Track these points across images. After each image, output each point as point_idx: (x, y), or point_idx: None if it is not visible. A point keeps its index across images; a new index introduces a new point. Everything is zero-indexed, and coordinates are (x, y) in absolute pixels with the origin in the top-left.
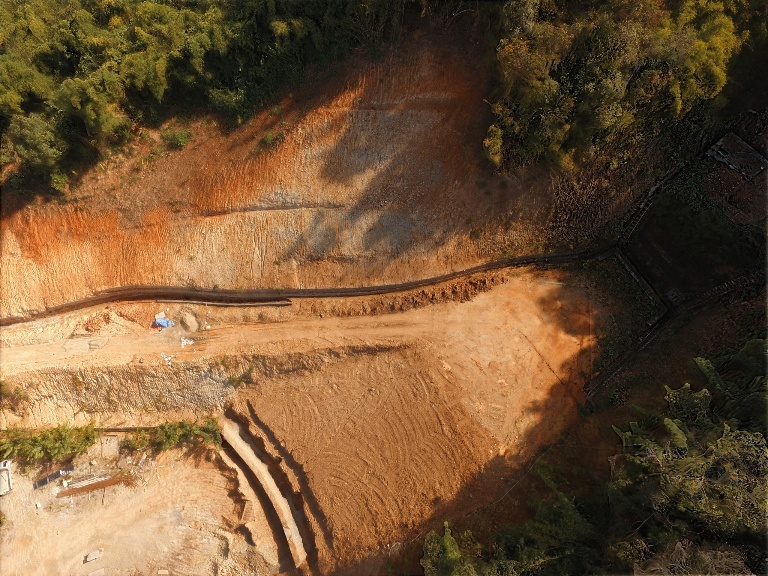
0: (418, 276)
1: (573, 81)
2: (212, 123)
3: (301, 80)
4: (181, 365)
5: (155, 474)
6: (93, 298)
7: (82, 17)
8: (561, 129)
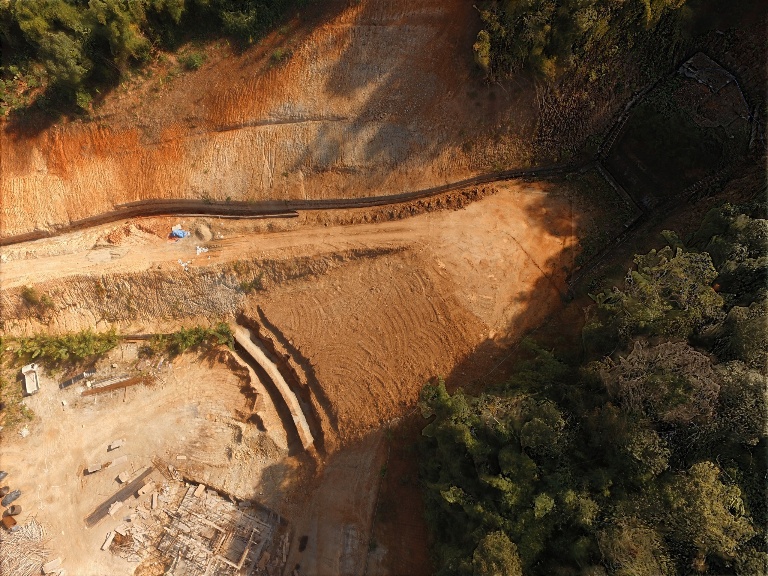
0: (415, 187)
1: None
2: (225, 45)
3: (307, 1)
4: (197, 270)
5: (172, 375)
6: (114, 213)
7: None
8: (542, 31)
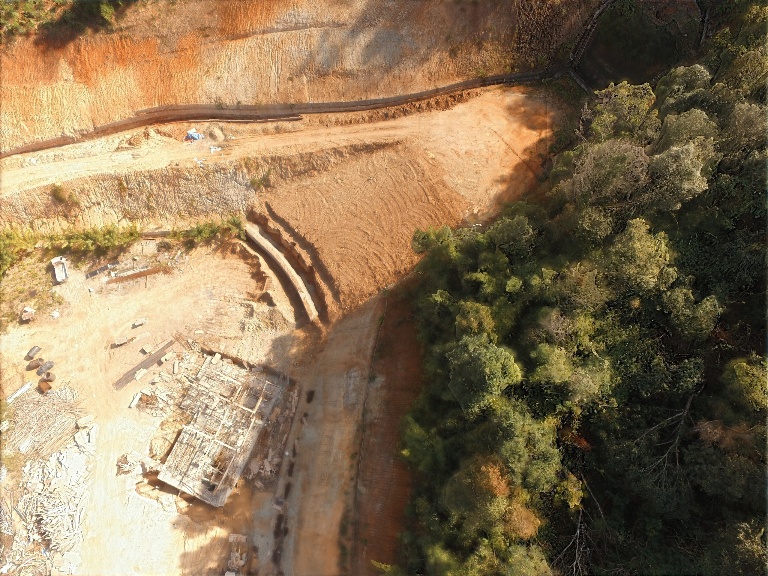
0: (407, 90)
1: None
2: None
3: None
4: (211, 167)
5: (189, 265)
6: (134, 119)
7: None
8: None
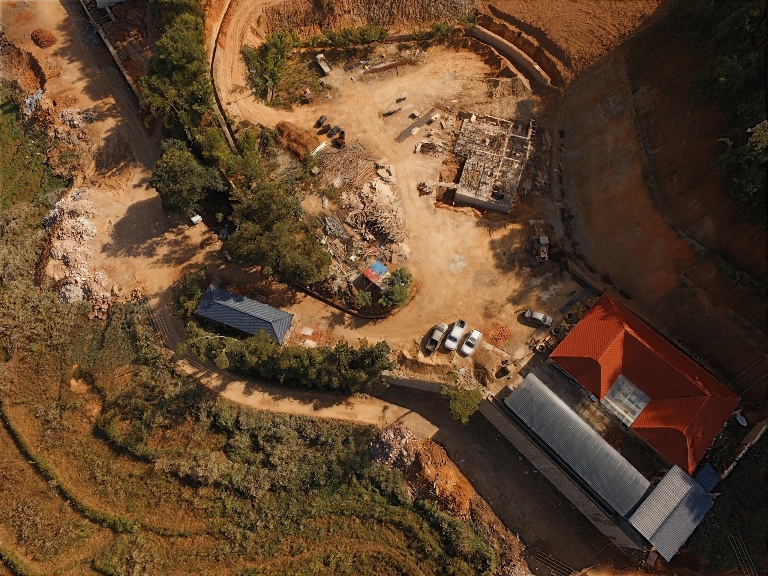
0: None
1: None
2: None
3: None
4: None
5: (429, 58)
6: None
7: None
8: None
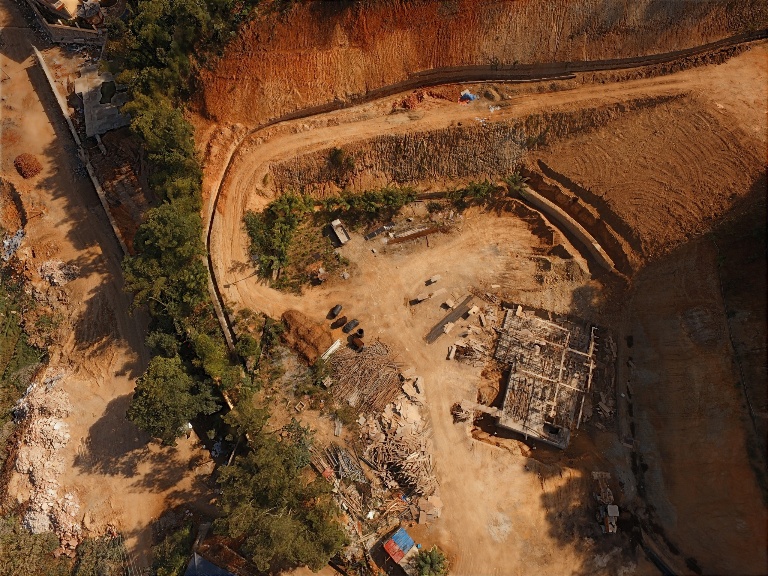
0: (681, 46)
1: None
2: None
3: None
4: (493, 125)
5: (466, 224)
6: (406, 82)
7: None
8: None
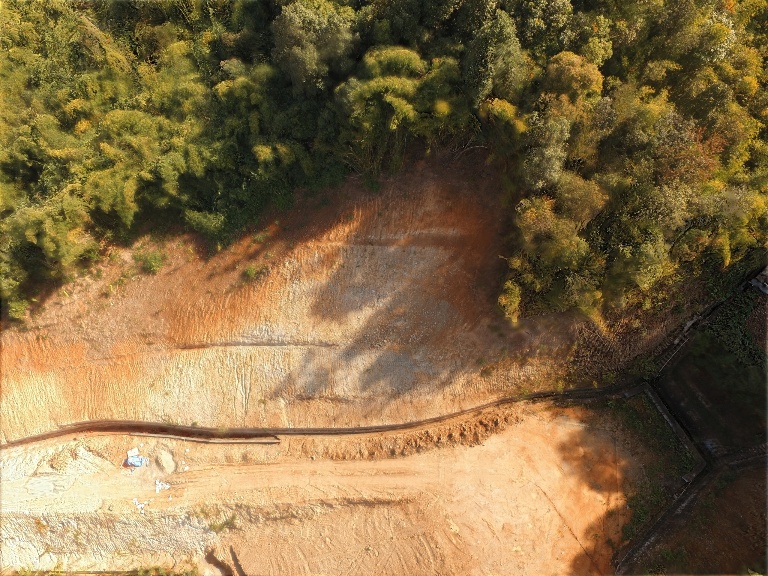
0: (422, 415)
1: (604, 235)
2: (189, 245)
3: (289, 205)
4: (155, 513)
5: None
6: (59, 430)
7: (44, 125)
8: (591, 293)
